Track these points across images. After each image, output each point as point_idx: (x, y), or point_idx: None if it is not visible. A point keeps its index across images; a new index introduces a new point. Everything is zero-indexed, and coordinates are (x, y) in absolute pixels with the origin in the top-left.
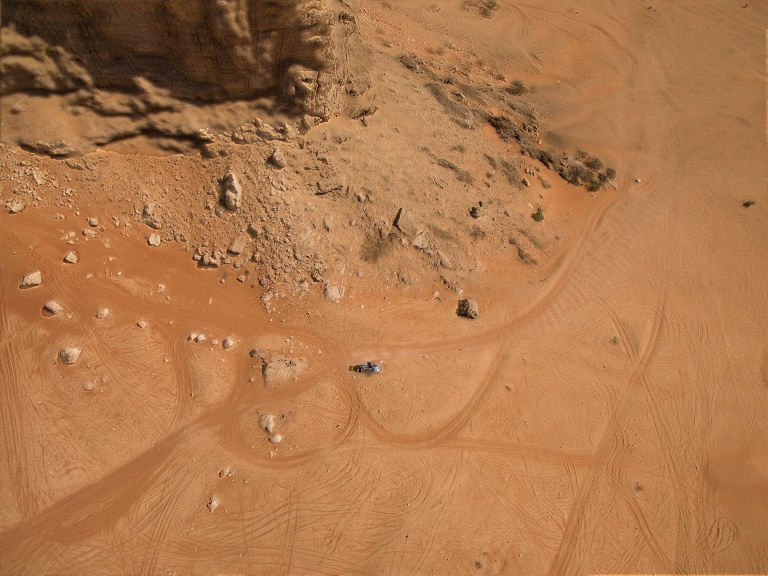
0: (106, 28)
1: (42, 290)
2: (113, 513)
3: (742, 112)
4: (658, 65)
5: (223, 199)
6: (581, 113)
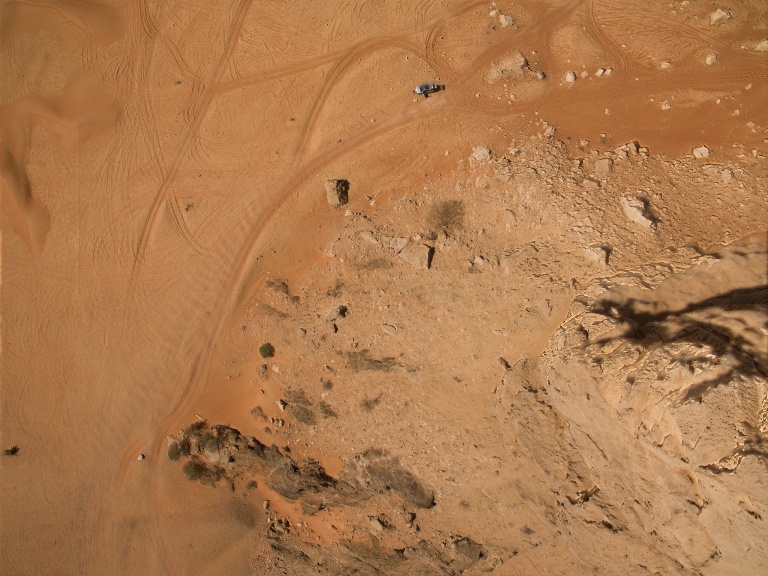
0: None
1: None
2: None
3: None
4: None
5: (646, 205)
6: None
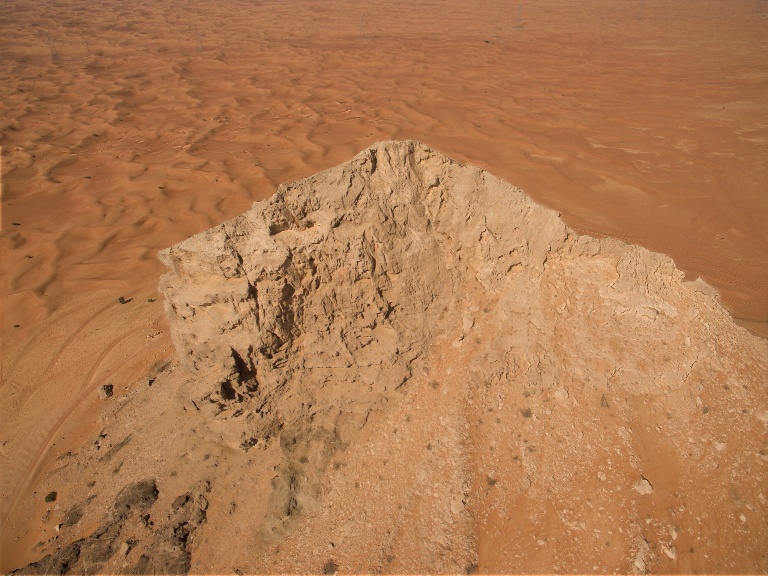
0: None
1: None
2: None
3: None
4: None
5: None
6: None
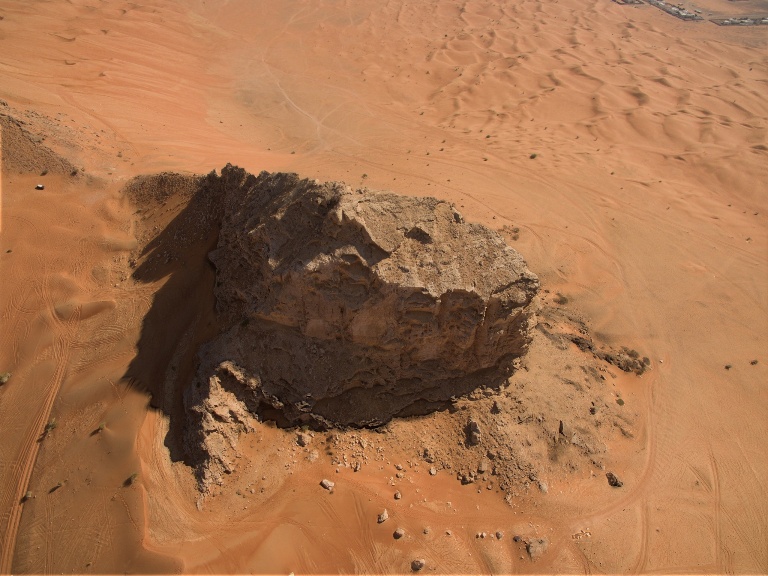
0: (413, 355)
1: (391, 522)
2: None
3: (697, 296)
4: (635, 266)
5: (469, 437)
6: (607, 313)
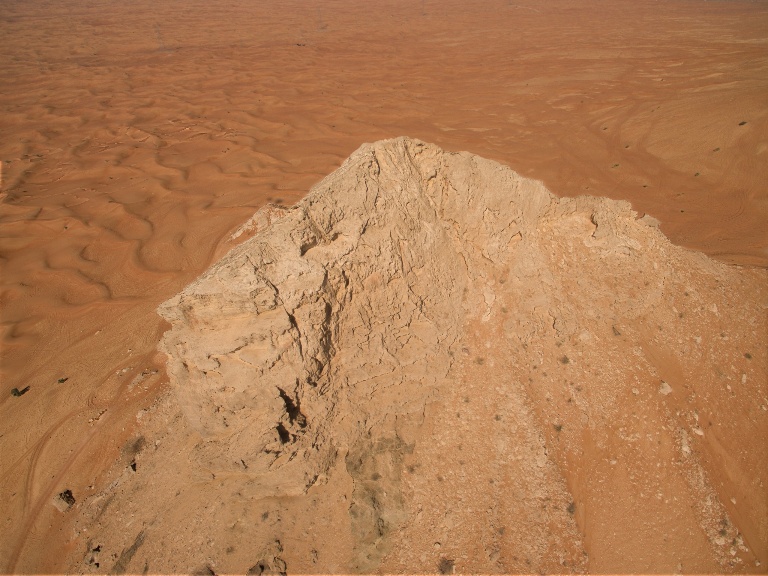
0: None
1: None
2: (163, 324)
3: None
4: None
5: None
6: None
